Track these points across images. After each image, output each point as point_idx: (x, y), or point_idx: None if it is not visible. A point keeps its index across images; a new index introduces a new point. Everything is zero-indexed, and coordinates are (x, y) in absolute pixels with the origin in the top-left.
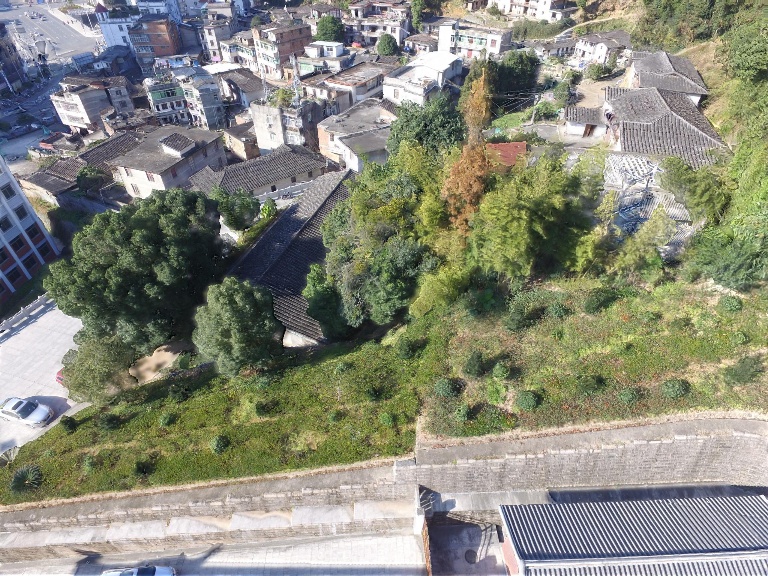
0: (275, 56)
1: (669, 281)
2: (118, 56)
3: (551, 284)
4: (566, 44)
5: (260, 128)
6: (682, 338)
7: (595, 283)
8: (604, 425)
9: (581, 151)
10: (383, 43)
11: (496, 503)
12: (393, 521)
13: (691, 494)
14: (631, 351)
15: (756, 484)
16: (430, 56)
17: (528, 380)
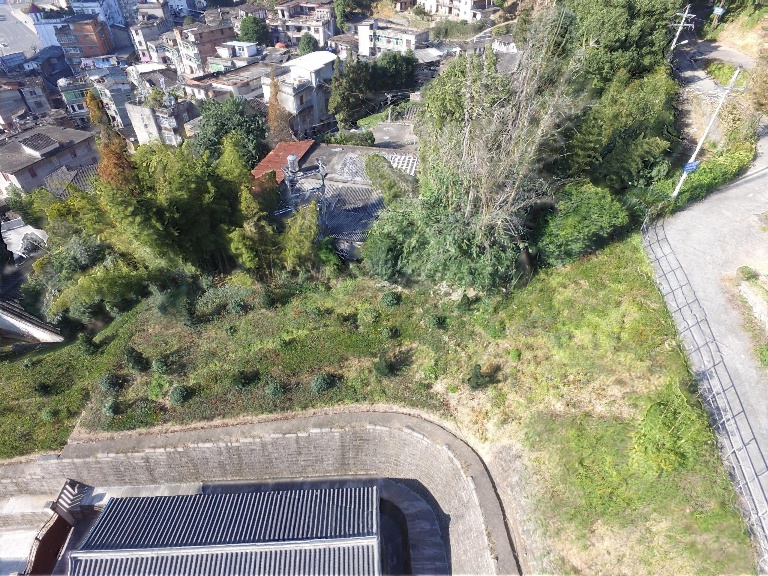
0: (195, 56)
1: (349, 277)
2: (51, 56)
3: None
4: (483, 44)
5: (138, 128)
6: (341, 333)
7: (245, 279)
8: (252, 419)
9: (365, 150)
10: (302, 43)
11: (145, 496)
12: (43, 515)
13: (341, 486)
14: (292, 346)
15: (402, 476)
16: (308, 56)
17: (191, 375)
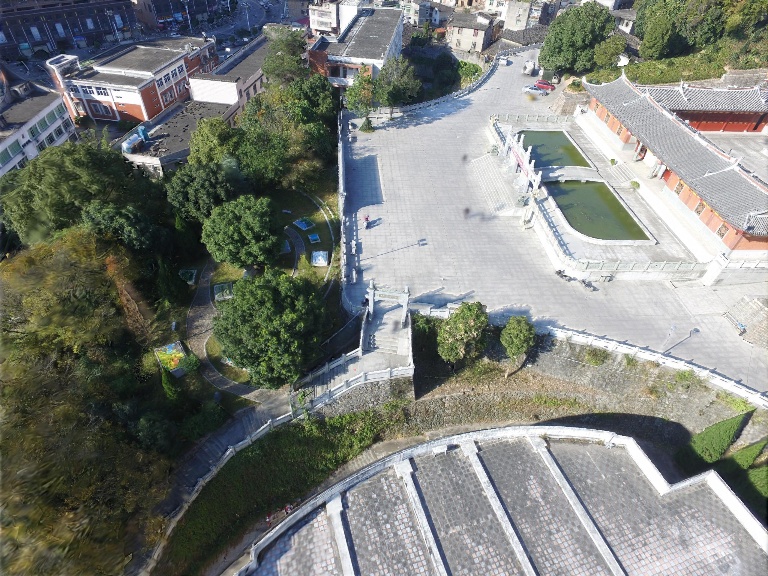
0: None
1: None
2: None
3: (765, 28)
4: None
5: (510, 17)
6: None
7: None
8: None
9: None
10: None
11: None
12: None
13: None
14: None
15: None
16: None
17: (762, 55)
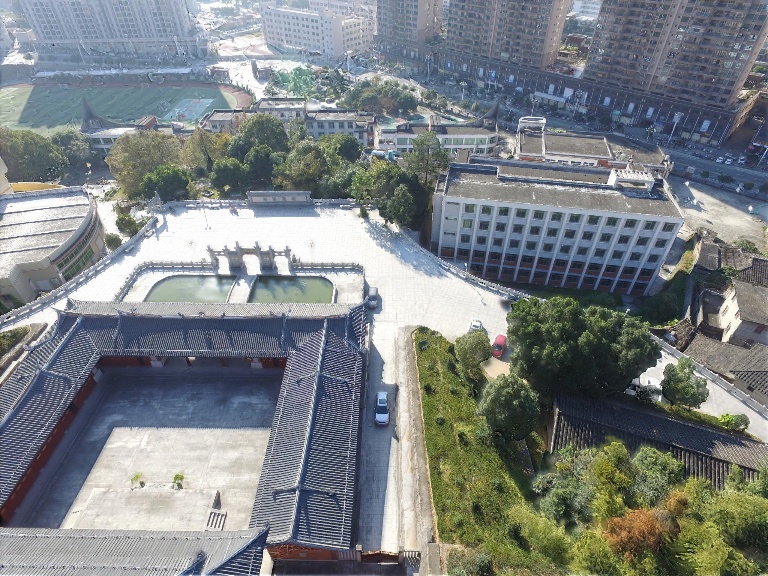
0: None
1: None
2: None
3: None
4: None
5: None
6: None
7: None
8: None
9: None
10: None
11: None
12: None
13: None
14: None
15: None
16: None
17: None
